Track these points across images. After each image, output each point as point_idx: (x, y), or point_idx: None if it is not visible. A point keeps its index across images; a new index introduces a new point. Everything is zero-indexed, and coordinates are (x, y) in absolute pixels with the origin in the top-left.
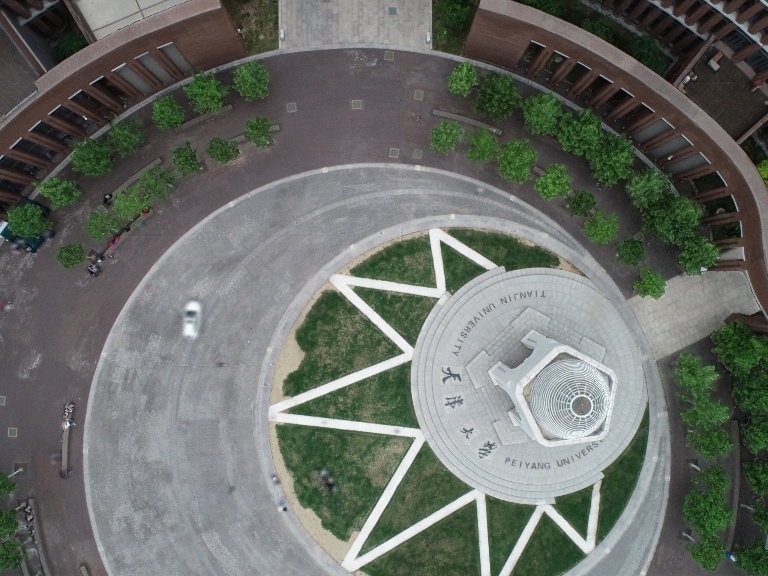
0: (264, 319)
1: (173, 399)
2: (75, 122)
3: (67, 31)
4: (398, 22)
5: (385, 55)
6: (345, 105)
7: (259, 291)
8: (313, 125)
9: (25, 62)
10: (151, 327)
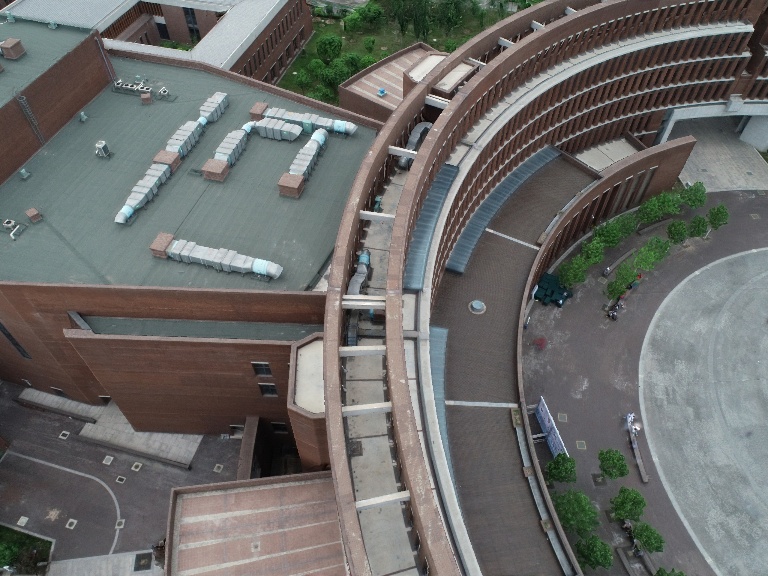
0: (762, 345)
1: (716, 409)
2: None
3: None
4: (756, 178)
5: (758, 192)
6: (747, 217)
7: (747, 326)
8: (731, 228)
9: (580, 171)
10: (672, 354)
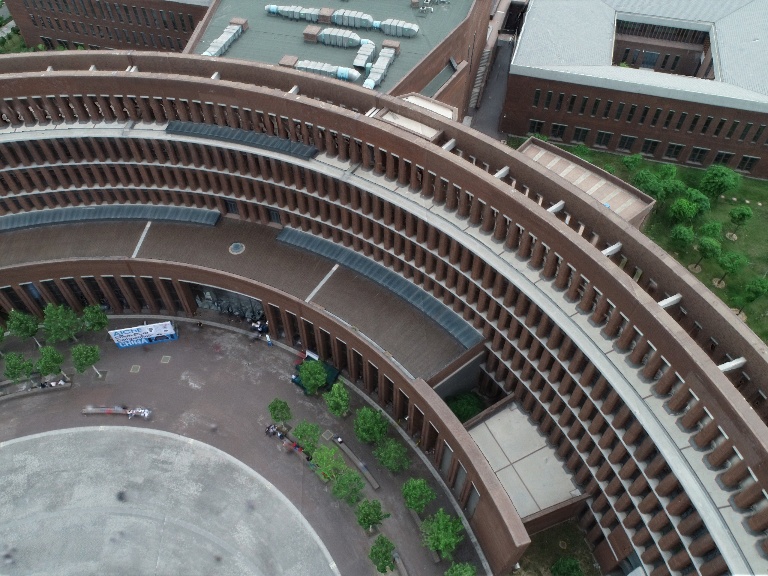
0: None
1: (133, 509)
2: (405, 410)
3: (484, 401)
4: None
5: None
6: None
7: None
8: None
9: None
10: (211, 484)
